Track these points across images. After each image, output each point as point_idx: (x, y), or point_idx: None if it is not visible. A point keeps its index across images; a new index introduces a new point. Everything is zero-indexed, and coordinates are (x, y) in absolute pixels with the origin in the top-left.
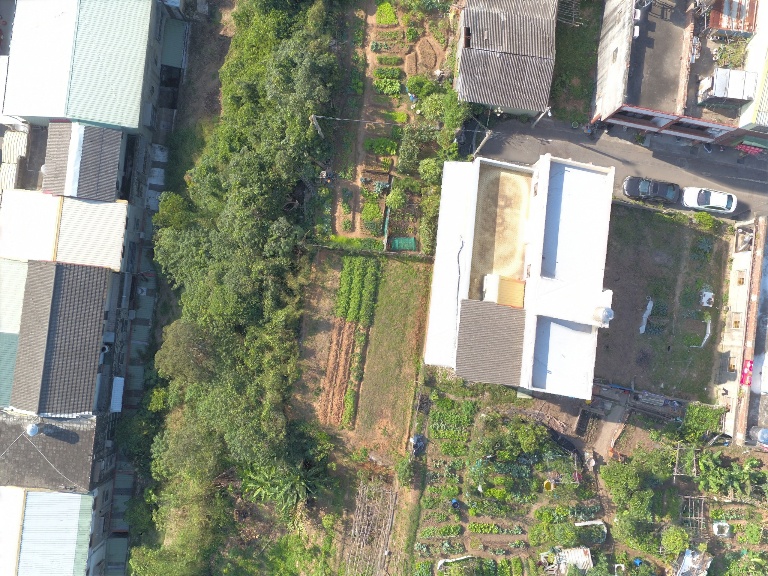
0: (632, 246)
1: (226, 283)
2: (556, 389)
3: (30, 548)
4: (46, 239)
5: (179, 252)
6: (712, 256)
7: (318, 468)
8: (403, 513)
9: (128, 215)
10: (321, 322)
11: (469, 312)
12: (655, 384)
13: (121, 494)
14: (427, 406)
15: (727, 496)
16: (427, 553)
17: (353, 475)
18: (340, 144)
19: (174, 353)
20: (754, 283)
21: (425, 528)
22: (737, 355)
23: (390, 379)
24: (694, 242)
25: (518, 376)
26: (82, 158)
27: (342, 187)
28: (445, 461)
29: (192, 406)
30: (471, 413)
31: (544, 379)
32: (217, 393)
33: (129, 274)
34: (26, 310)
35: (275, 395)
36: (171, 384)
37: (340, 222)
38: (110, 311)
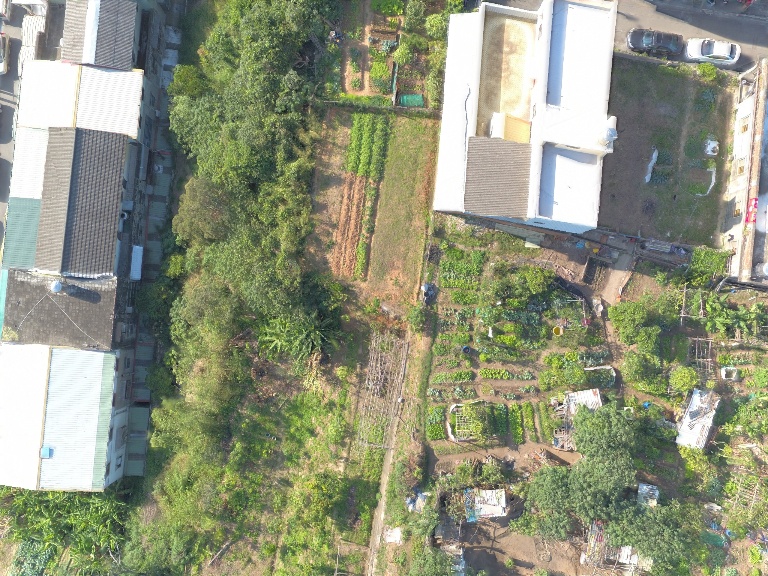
0: (637, 97)
1: (240, 137)
2: (563, 219)
3: (56, 403)
4: (66, 107)
5: (194, 118)
6: (717, 106)
7: (332, 319)
8: (415, 361)
9: (144, 87)
10: (333, 177)
11: (476, 149)
12: (661, 233)
13: (142, 365)
14: (437, 256)
15: (734, 338)
16: (439, 398)
17: (366, 330)
18: (348, 5)
19: (191, 208)
20: (758, 124)
21: (437, 374)
22: (742, 198)
23: (401, 232)
24: (698, 93)
25: (525, 208)
26: (99, 27)
27: (351, 47)
28: (456, 309)
29: (209, 271)
30: (480, 262)
31: (551, 210)
32: (233, 246)
33: (146, 146)
34: (48, 175)
35: (289, 245)
36: (188, 251)
37: (350, 81)
38: (128, 182)
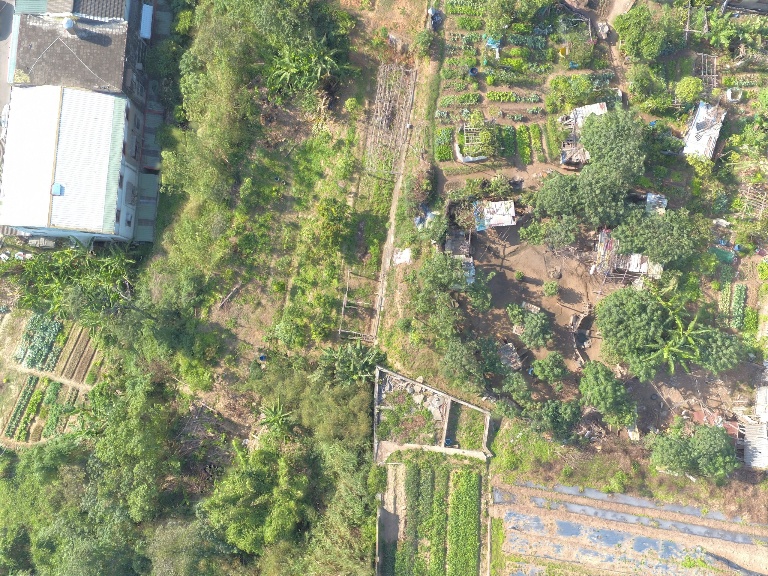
0: None
1: None
2: None
3: (67, 141)
4: None
5: None
6: None
7: (340, 50)
8: (423, 87)
9: None
10: None
11: None
12: None
13: (151, 133)
14: None
15: (739, 54)
16: (448, 119)
17: (374, 66)
18: None
19: None
20: None
21: (445, 96)
22: None
23: None
24: None
25: None
26: None
27: None
28: (463, 34)
29: None
30: None
31: None
32: None
33: None
34: None
35: None
36: (198, 8)
37: None
38: None
